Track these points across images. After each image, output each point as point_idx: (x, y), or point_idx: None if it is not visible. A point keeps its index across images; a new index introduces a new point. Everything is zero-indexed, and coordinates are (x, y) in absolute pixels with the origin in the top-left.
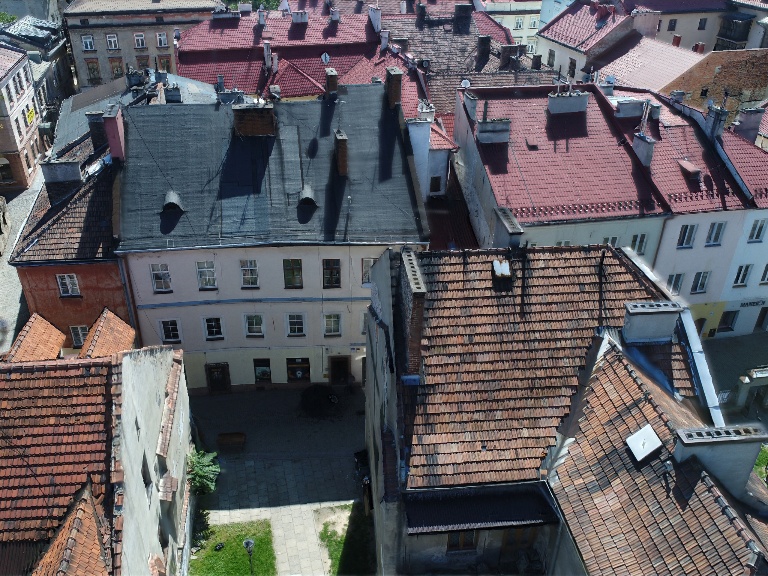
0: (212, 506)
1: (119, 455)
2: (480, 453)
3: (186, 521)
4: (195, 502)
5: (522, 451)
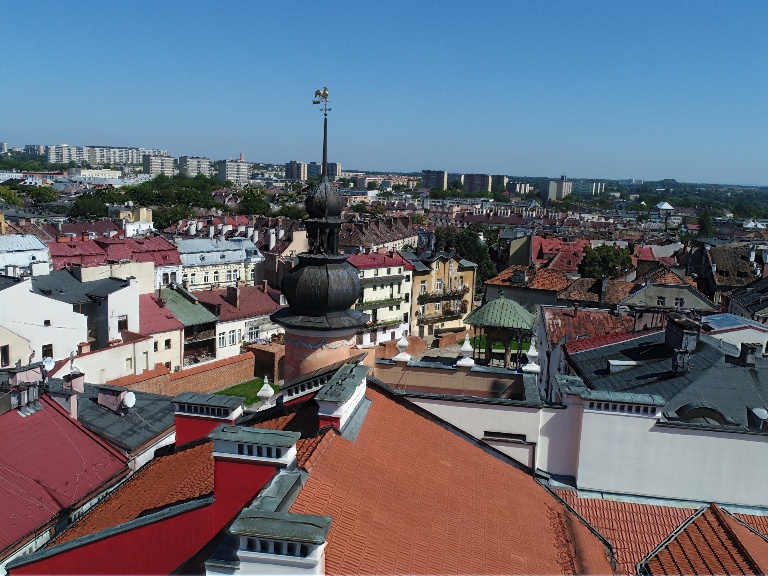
0: None
1: None
2: None
3: None
4: None
5: None
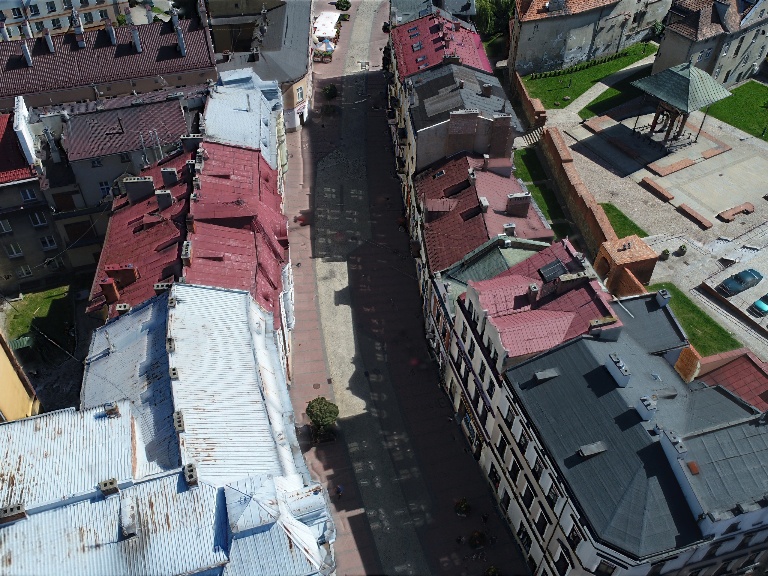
0: (654, 40)
1: None
2: (693, 4)
3: (644, 32)
4: (651, 36)
5: (701, 7)
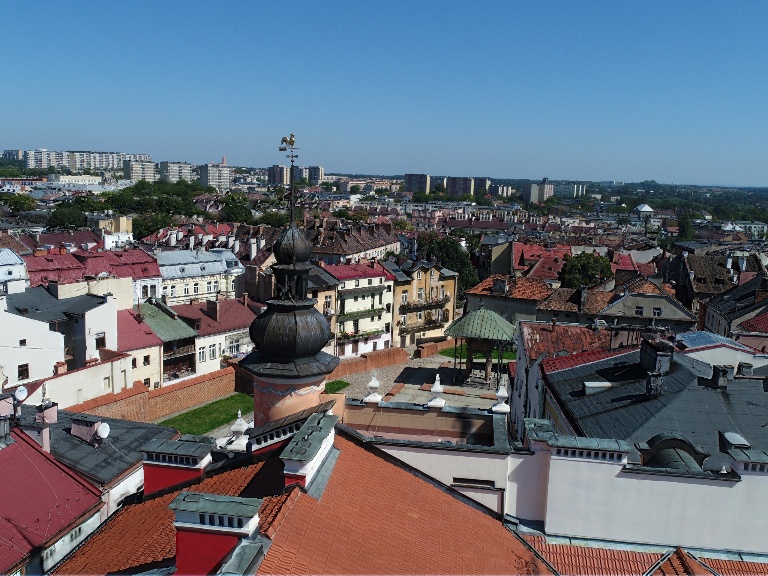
0: None
1: (599, 288)
2: None
3: None
4: None
5: None
